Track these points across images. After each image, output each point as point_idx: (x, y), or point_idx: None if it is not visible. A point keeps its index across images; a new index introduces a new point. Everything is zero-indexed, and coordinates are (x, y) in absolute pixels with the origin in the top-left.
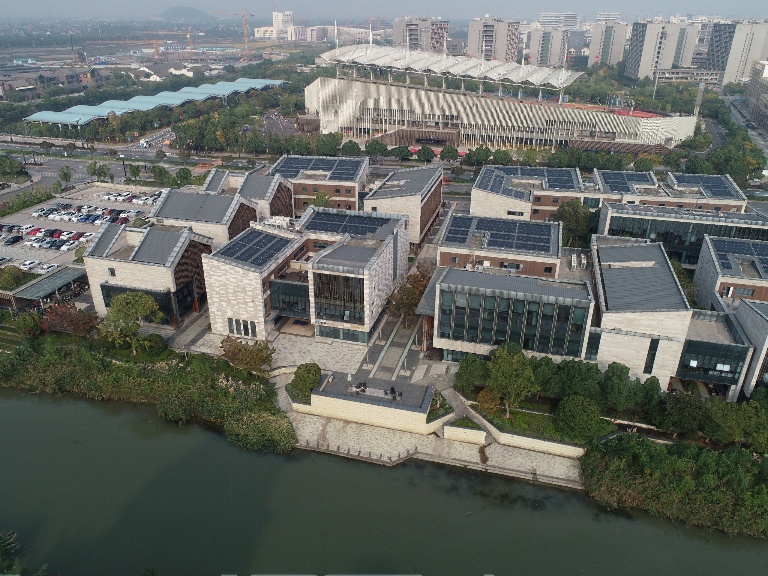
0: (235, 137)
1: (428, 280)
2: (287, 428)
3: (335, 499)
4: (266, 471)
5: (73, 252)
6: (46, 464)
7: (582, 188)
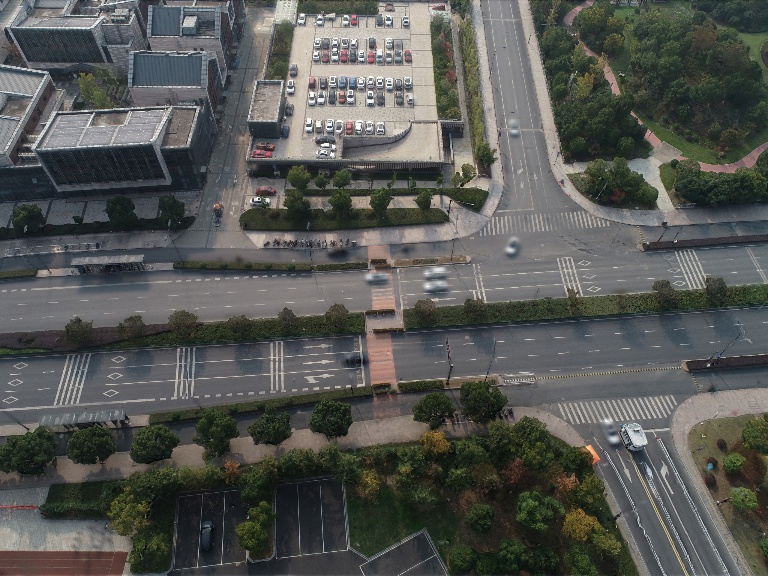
0: (399, 452)
1: None
2: None
3: None
4: None
5: (309, 40)
6: None
7: None
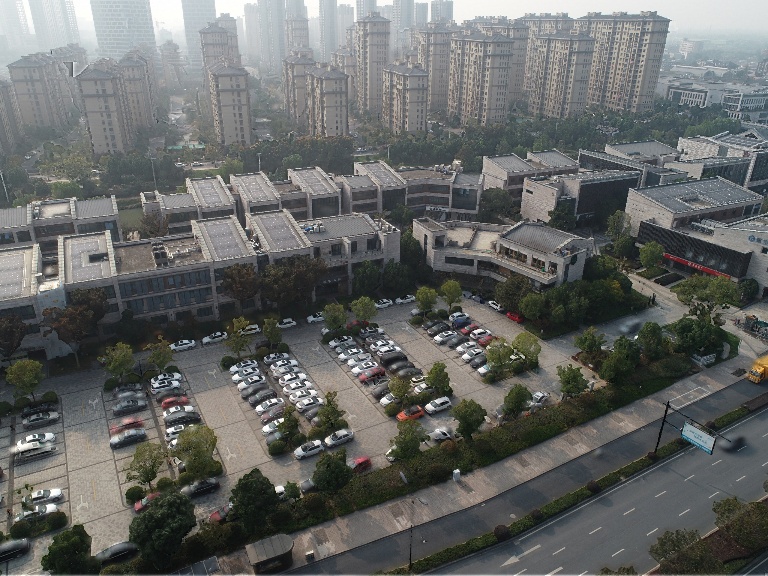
0: None
1: None
2: None
3: None
4: None
5: None
6: None
7: None
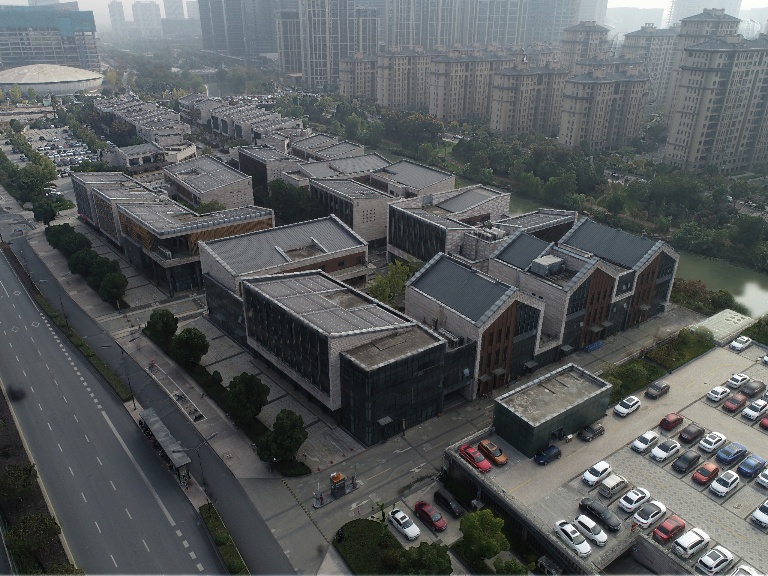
0: None
1: None
2: None
3: None
4: None
5: (727, 371)
6: None
7: (172, 202)
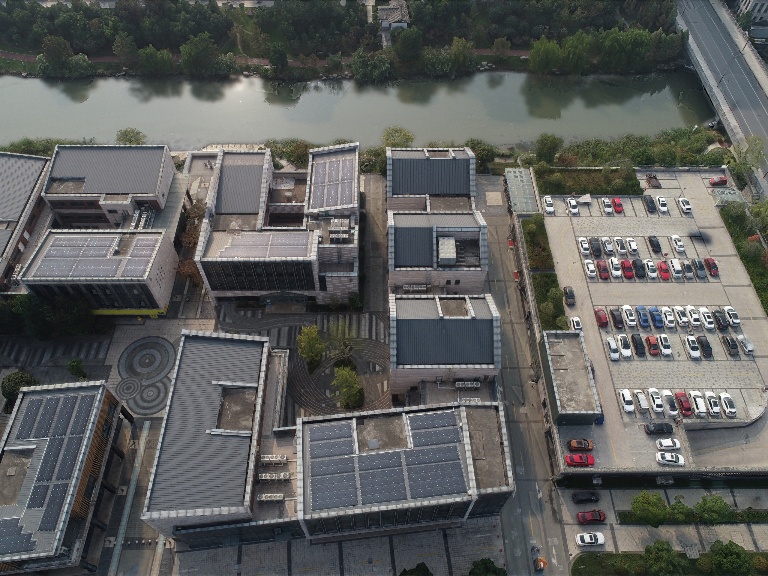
0: None
1: (183, 239)
2: (271, 144)
3: (236, 126)
4: (276, 132)
5: (570, 240)
6: (386, 113)
7: None
